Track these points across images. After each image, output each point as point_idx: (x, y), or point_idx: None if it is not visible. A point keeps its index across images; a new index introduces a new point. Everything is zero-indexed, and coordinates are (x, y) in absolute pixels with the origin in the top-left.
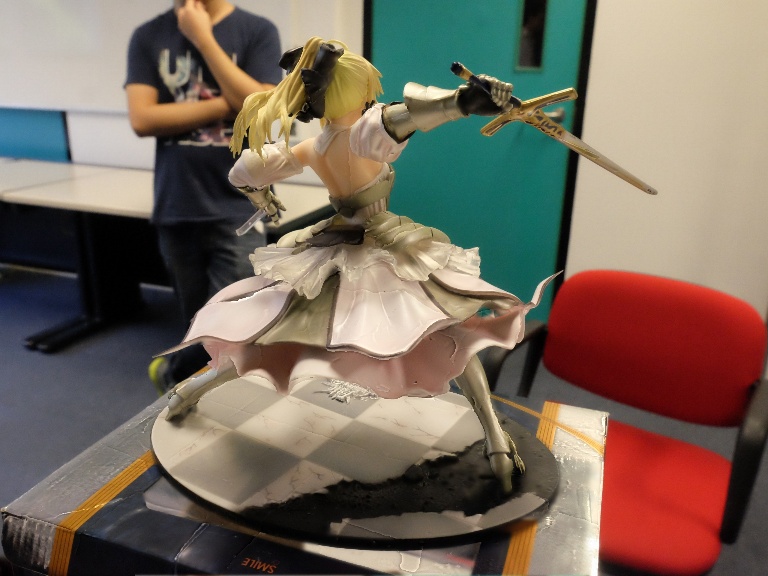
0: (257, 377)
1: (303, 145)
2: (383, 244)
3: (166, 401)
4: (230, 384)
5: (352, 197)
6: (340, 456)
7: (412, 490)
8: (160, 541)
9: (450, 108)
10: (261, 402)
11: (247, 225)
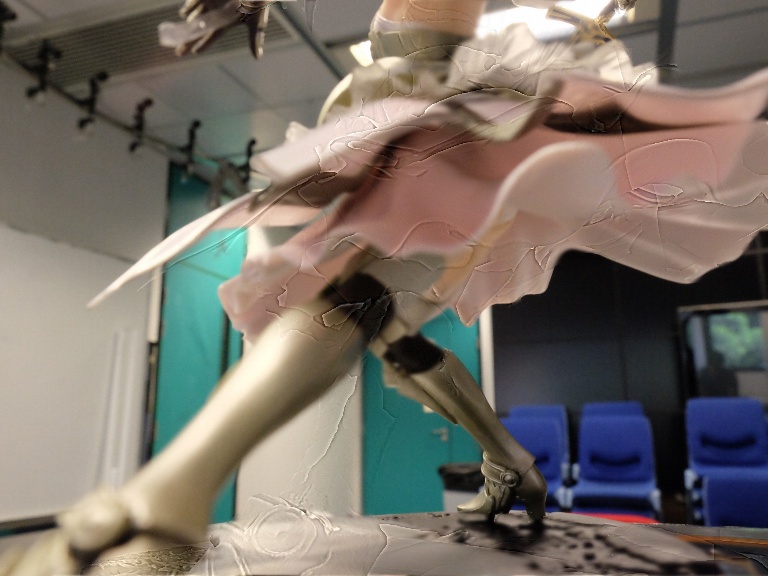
0: None
1: None
2: None
3: None
4: None
5: None
6: (484, 574)
7: (556, 555)
8: None
9: None
10: None
11: None
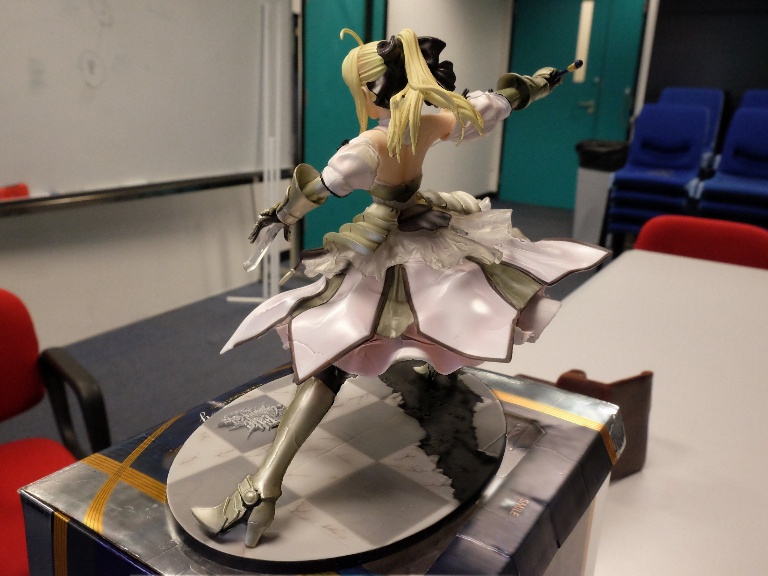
0: (180, 470)
1: (377, 138)
2: (464, 211)
3: (169, 561)
4: (184, 491)
5: (416, 180)
6: (379, 442)
7: (435, 421)
8: (480, 567)
9: (543, 92)
10: (247, 474)
11: (260, 253)
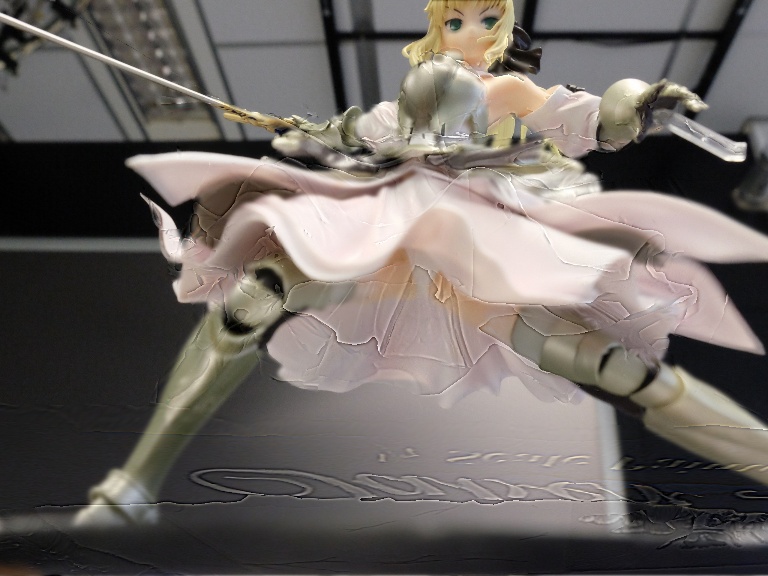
0: None
1: None
2: None
3: None
4: None
5: None
6: None
7: None
8: None
9: None
10: None
11: None
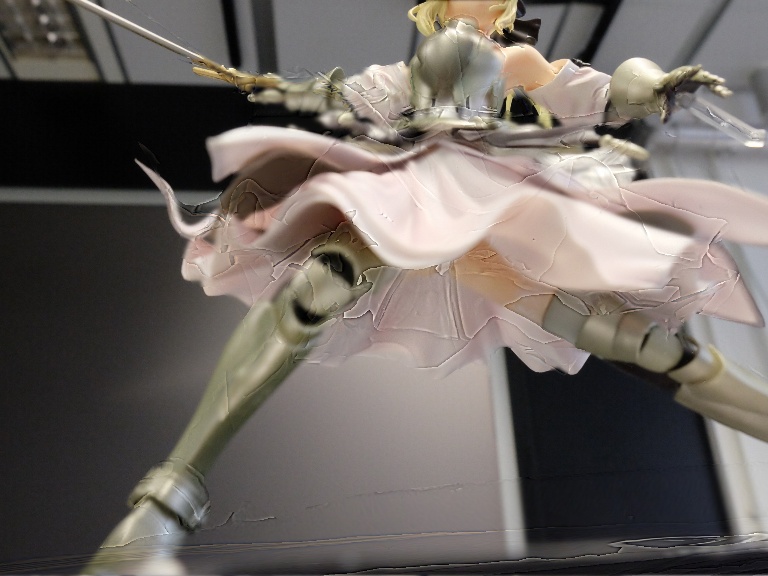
0: None
1: None
2: None
3: None
4: None
5: None
6: None
7: None
8: None
9: None
10: None
11: None
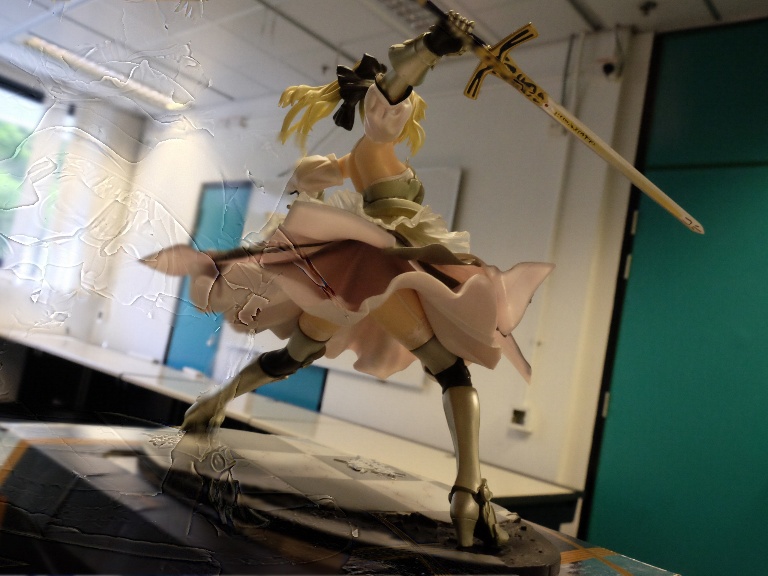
0: None
1: None
2: None
3: None
4: (70, 407)
5: None
6: (49, 459)
7: None
8: None
9: None
10: (70, 420)
11: None
